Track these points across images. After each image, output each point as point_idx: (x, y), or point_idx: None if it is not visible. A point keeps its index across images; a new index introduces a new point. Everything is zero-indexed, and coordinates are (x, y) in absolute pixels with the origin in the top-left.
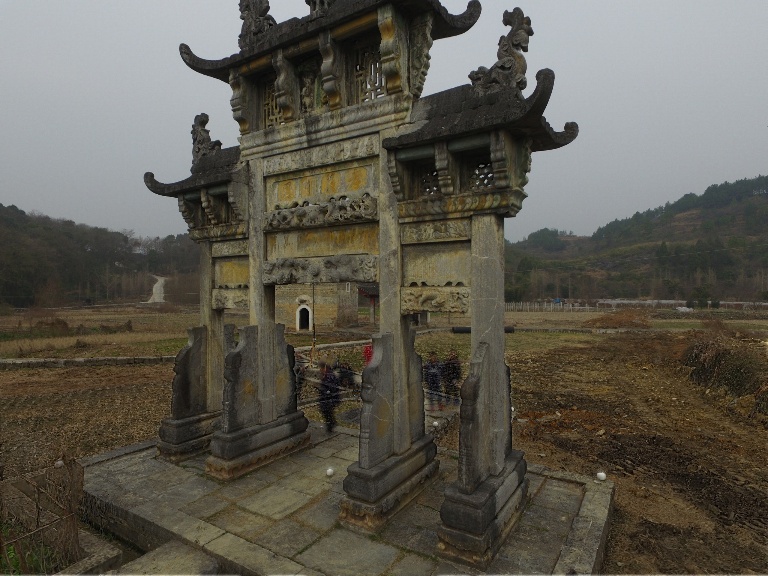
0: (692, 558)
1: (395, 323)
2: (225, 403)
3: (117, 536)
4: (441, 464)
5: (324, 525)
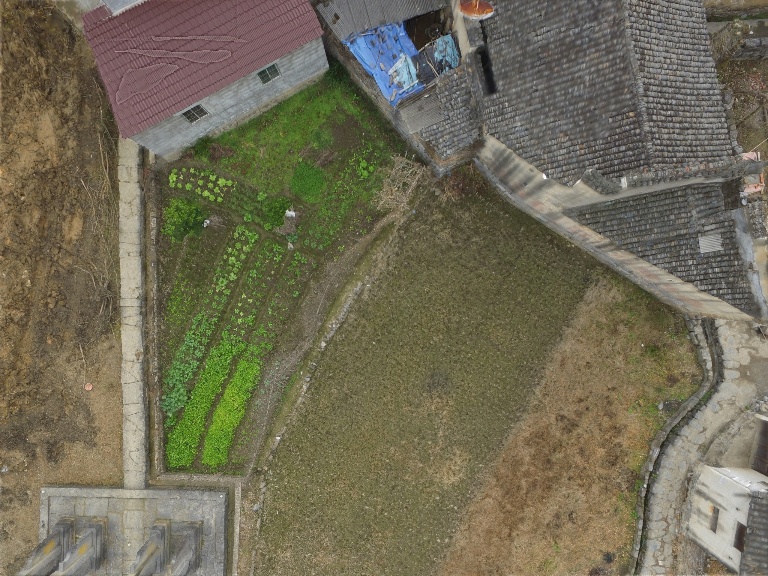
0: (25, 563)
1: (55, 574)
2: (149, 539)
3: (178, 486)
4: (99, 575)
5: (110, 515)
